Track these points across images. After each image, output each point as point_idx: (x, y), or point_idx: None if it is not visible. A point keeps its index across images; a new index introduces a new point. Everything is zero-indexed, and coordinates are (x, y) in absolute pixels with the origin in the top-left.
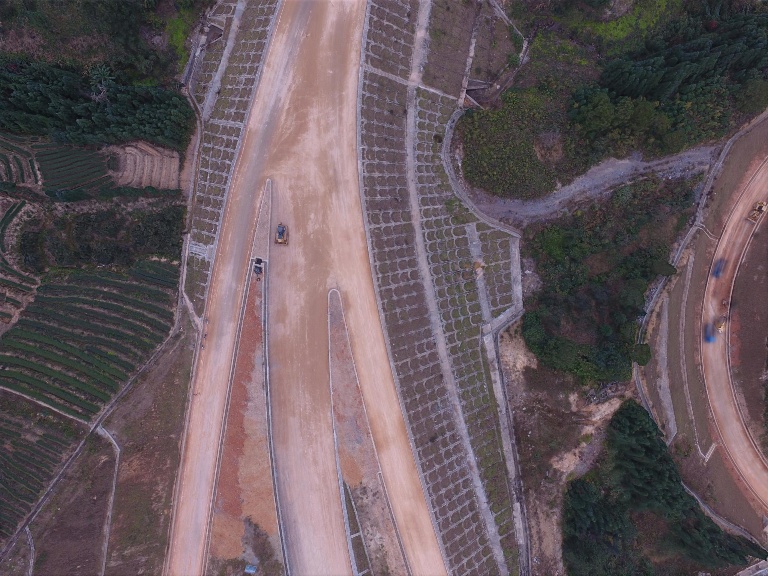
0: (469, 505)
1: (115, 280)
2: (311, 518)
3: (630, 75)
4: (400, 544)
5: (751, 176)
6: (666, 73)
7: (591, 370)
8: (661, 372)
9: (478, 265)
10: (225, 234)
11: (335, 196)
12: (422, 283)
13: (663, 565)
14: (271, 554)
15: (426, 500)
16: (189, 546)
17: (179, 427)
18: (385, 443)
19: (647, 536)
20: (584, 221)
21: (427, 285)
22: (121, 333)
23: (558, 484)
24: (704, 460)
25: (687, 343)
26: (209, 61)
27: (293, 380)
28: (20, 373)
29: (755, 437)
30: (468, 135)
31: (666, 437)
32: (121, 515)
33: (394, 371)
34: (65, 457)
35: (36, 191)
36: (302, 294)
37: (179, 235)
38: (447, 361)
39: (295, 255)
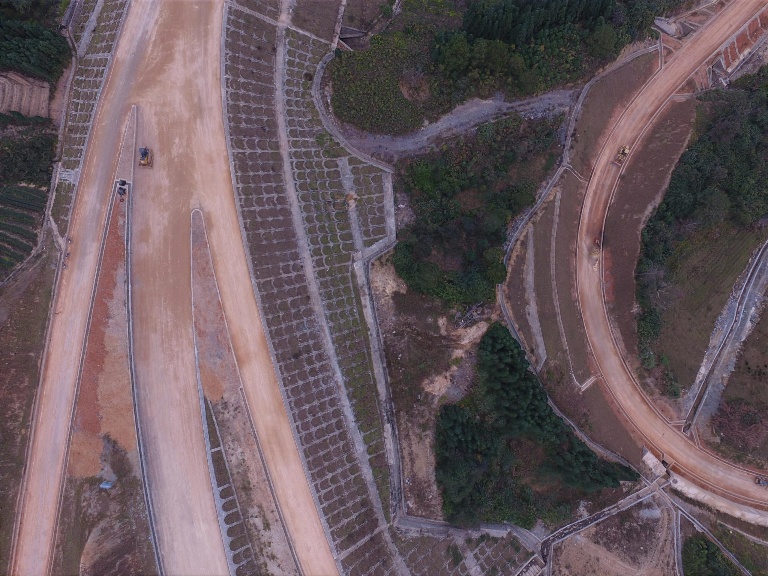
0: (336, 423)
1: None
2: (171, 433)
3: (483, 17)
4: (262, 459)
5: (615, 122)
6: (518, 17)
7: (456, 293)
8: (529, 299)
9: (350, 197)
10: (90, 157)
11: (199, 122)
12: (290, 209)
13: (545, 494)
14: (129, 470)
15: (287, 413)
16: (47, 466)
17: (39, 345)
18: (247, 358)
19: (526, 464)
20: (451, 156)
21: (295, 211)
22: None
23: (430, 407)
24: (580, 389)
25: (559, 277)
26: (88, 4)
27: (155, 297)
28: None
29: (632, 370)
30: (335, 72)
31: (536, 362)
32: None
33: (255, 287)
34: None
35: None
36: (166, 214)
37: (48, 161)
38: (314, 283)
39: (159, 177)
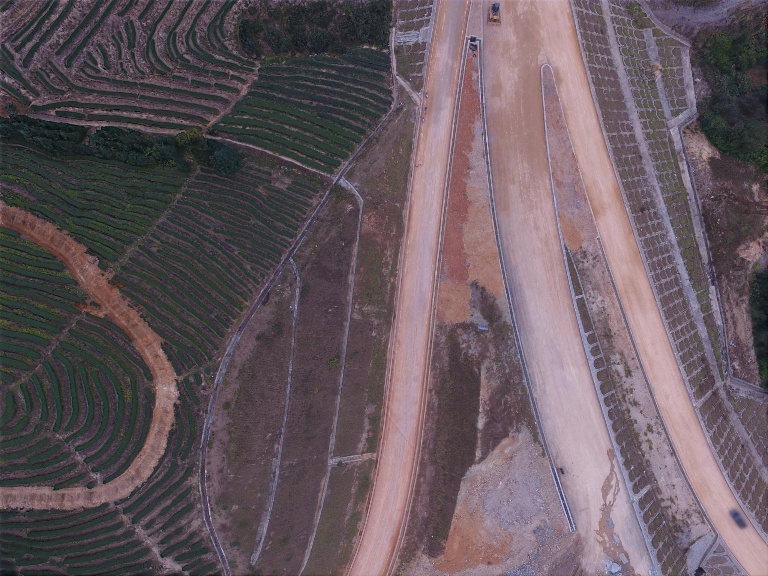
0: (675, 280)
1: (331, 64)
2: (536, 281)
3: None
4: (620, 307)
5: None
6: None
7: None
8: None
9: (656, 68)
10: (440, 15)
11: None
12: (616, 72)
13: None
14: (500, 315)
15: (644, 263)
16: (414, 314)
17: (403, 196)
18: (601, 209)
19: None
20: (752, 27)
21: (621, 74)
22: (348, 103)
23: (746, 272)
24: None
25: None
26: None
27: (511, 150)
28: (261, 131)
29: None
30: None
31: None
32: (362, 268)
33: (607, 140)
34: (315, 202)
35: None
36: (515, 70)
37: (389, 24)
38: (644, 144)
39: (507, 34)
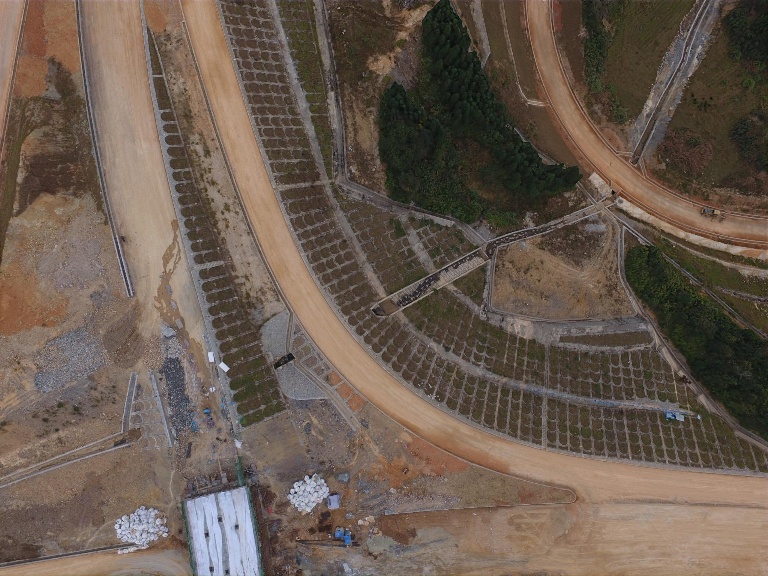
0: (278, 76)
1: None
2: (114, 59)
3: None
4: (203, 90)
5: None
6: None
7: None
8: None
9: None
10: None
11: None
12: None
13: (491, 200)
14: (73, 89)
15: (228, 48)
16: None
17: None
18: None
19: (472, 165)
20: None
21: None
22: None
23: (374, 84)
24: (526, 102)
25: None
26: None
27: None
28: None
29: (580, 99)
30: None
31: (480, 56)
32: None
33: None
34: None
35: None
36: None
37: None
38: None
39: None
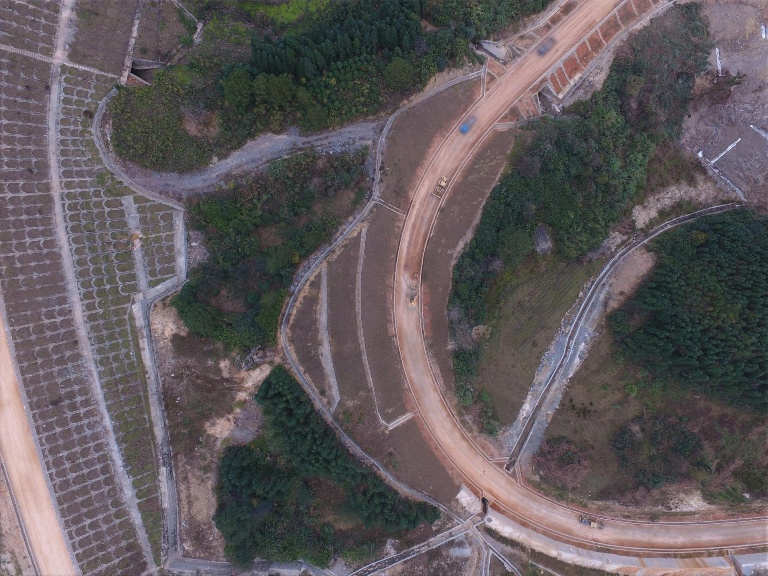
0: (101, 468)
1: None
2: None
3: (261, 52)
4: (15, 505)
5: (434, 153)
6: None
7: (234, 336)
8: (322, 340)
9: (136, 237)
10: None
11: None
12: (59, 252)
13: (348, 532)
14: None
15: (39, 461)
16: None
17: None
18: (0, 406)
19: (325, 503)
20: (240, 194)
21: (65, 254)
22: None
23: (211, 449)
24: (387, 428)
25: (367, 314)
26: None
27: None
28: None
29: (452, 407)
30: (112, 110)
31: (328, 403)
32: None
33: (9, 335)
34: None
35: None
36: None
37: None
38: (83, 328)
39: None
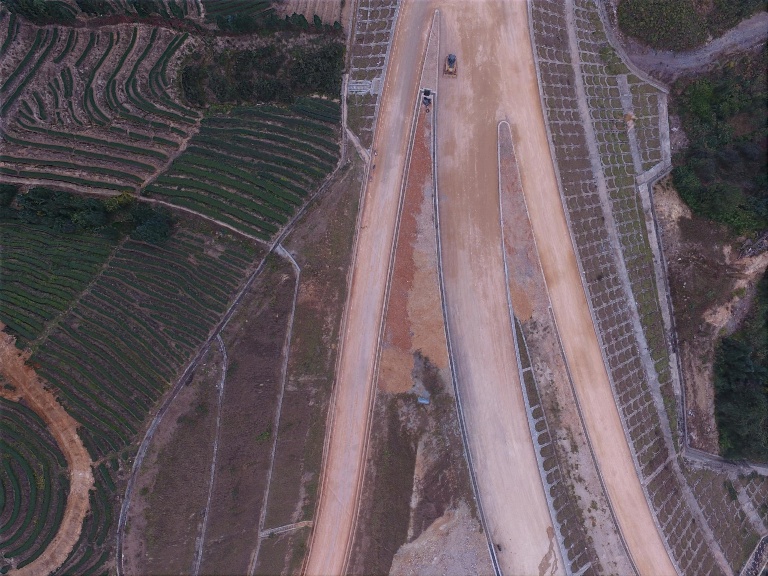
0: (631, 349)
1: (278, 115)
2: (482, 352)
3: None
4: (570, 380)
5: None
6: None
7: (749, 218)
8: None
9: (629, 117)
10: (392, 66)
11: (503, 28)
12: (582, 126)
13: None
14: (442, 387)
15: (597, 335)
16: (356, 382)
17: (347, 260)
18: (555, 278)
19: None
20: (735, 74)
21: (587, 128)
22: (291, 161)
23: (711, 338)
24: None
25: None
26: None
27: (462, 213)
28: (197, 193)
29: None
30: None
31: None
32: (298, 339)
33: (565, 204)
34: (248, 272)
35: (199, 24)
36: (471, 126)
37: None
38: (608, 204)
39: (463, 87)
